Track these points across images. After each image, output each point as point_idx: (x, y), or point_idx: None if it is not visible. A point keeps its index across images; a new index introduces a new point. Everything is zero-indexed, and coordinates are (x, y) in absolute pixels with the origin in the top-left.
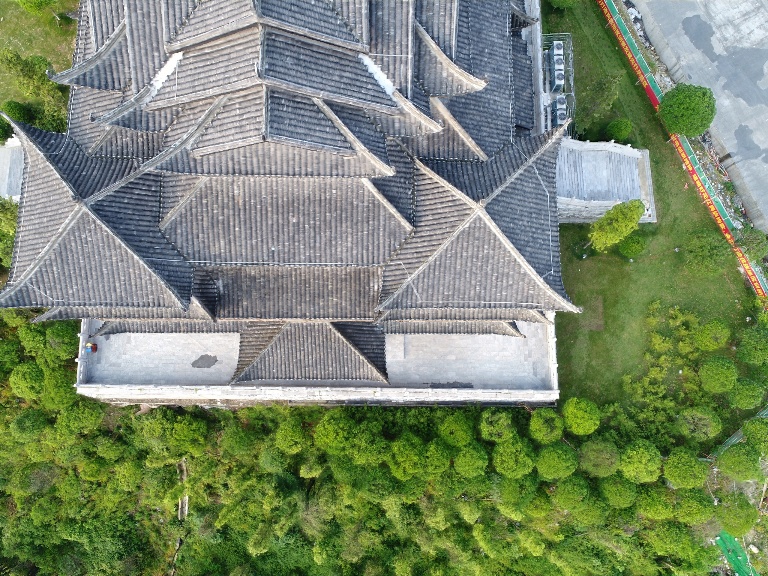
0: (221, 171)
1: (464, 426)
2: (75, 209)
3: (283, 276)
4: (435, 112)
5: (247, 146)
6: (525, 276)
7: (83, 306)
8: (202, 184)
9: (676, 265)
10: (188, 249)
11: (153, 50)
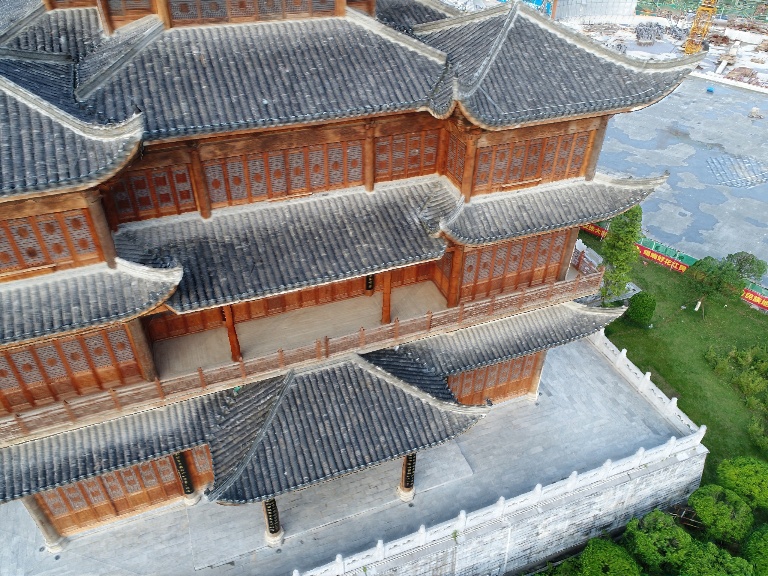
0: None
1: (616, 549)
2: None
3: (276, 234)
4: (412, 2)
5: None
6: (610, 67)
7: None
8: (143, 48)
9: (695, 320)
10: None
11: None
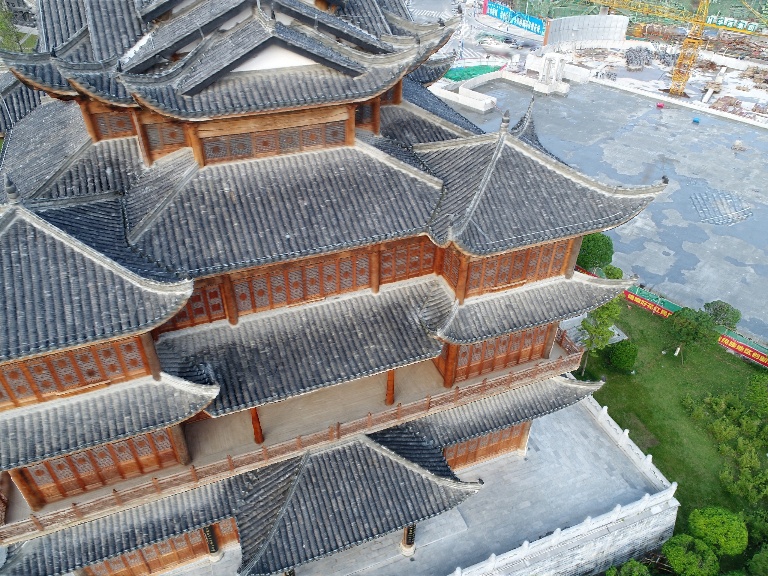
0: (217, 108)
1: None
2: (6, 212)
3: (295, 338)
4: (411, 116)
5: (244, 82)
6: (585, 191)
7: (5, 355)
8: (181, 188)
9: (674, 365)
10: (172, 260)
11: (120, 35)
